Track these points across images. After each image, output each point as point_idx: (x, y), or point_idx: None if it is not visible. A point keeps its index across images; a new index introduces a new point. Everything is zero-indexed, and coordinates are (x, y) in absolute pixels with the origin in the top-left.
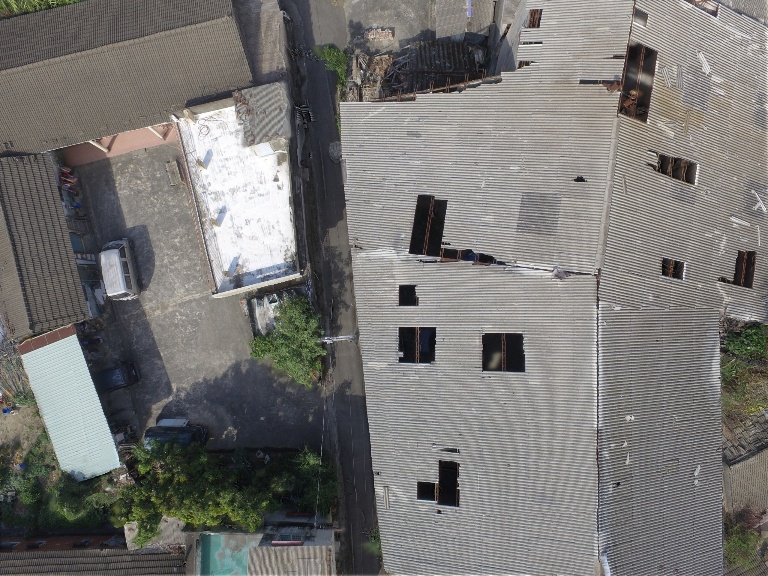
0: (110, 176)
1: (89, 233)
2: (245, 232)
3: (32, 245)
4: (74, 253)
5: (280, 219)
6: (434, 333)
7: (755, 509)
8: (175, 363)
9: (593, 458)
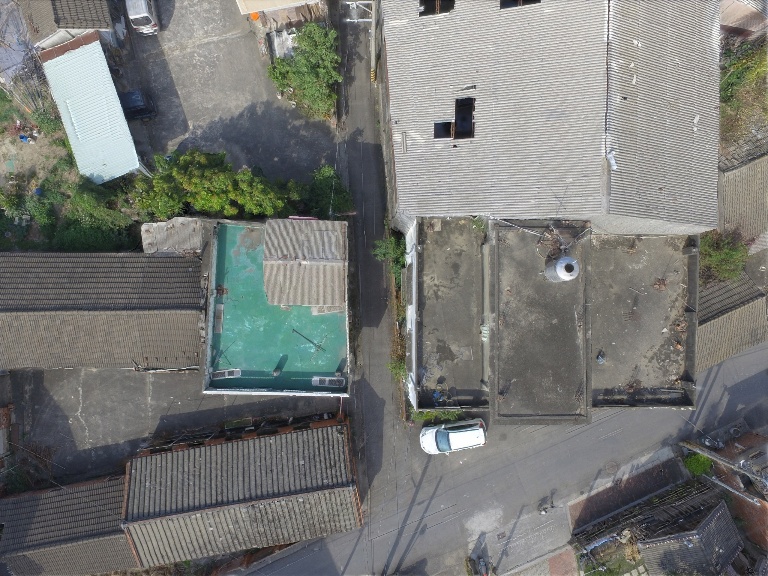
0: None
1: None
2: None
3: None
4: None
5: None
6: None
7: (745, 236)
8: (192, 102)
9: (603, 68)
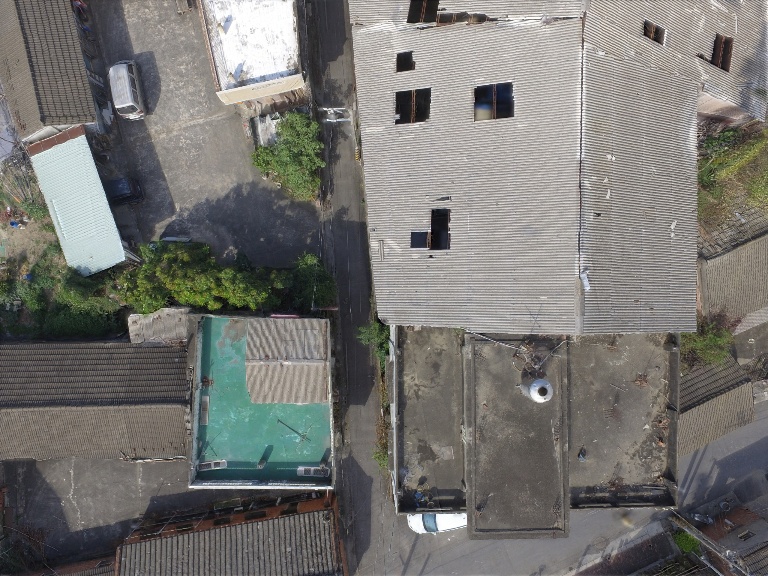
0: (119, 4)
1: (98, 57)
2: (250, 40)
3: (44, 45)
4: (84, 61)
5: (284, 29)
6: (429, 92)
7: (731, 317)
8: (179, 184)
9: (576, 186)
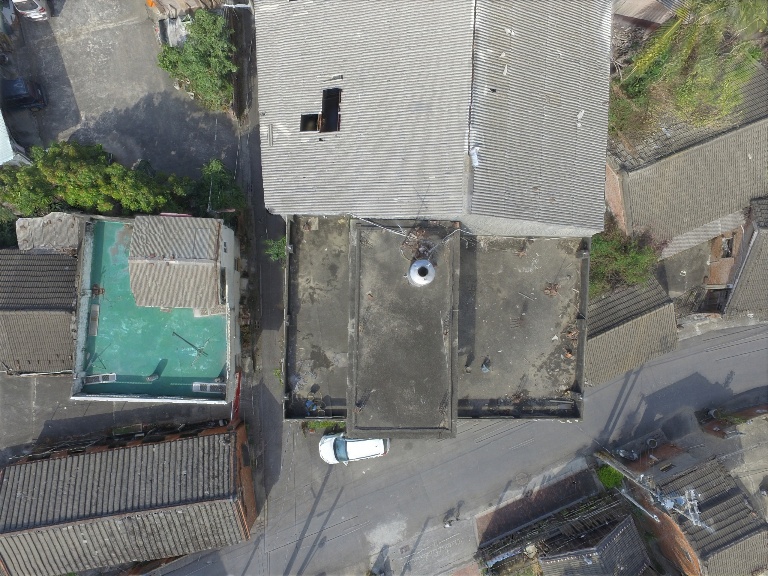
0: None
1: None
2: None
3: None
4: None
5: None
6: None
7: (656, 239)
8: (85, 91)
9: (468, 57)
